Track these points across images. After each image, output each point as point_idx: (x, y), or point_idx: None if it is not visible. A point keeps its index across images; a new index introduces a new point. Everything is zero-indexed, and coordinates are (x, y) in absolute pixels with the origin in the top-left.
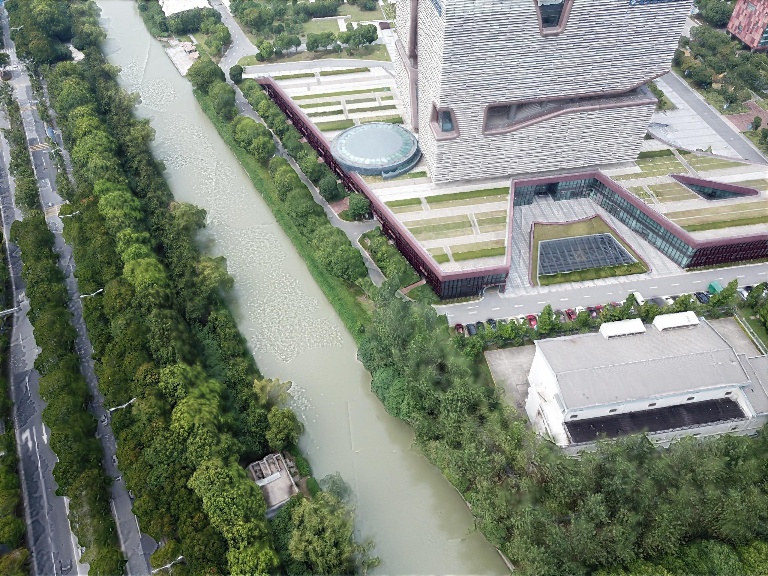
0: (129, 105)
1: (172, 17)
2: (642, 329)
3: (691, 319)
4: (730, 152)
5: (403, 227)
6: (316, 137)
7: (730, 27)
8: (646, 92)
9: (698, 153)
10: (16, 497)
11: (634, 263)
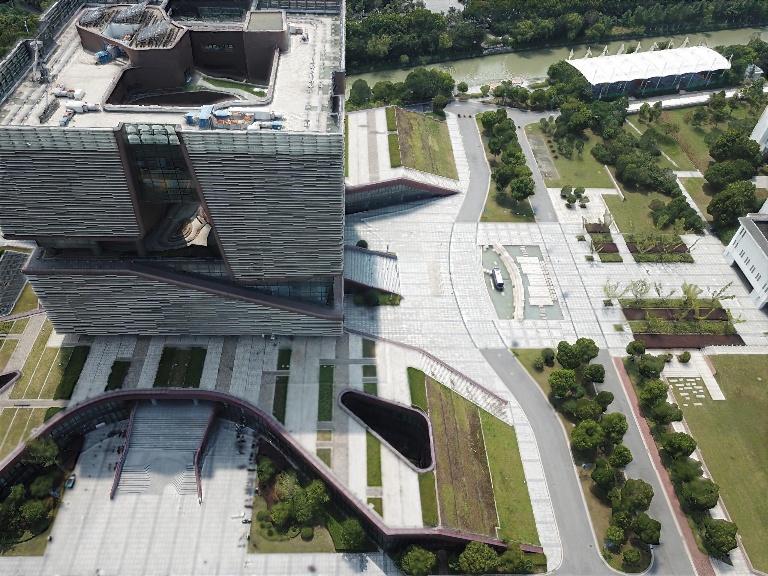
0: (369, 47)
1: (559, 62)
2: None
3: None
4: (82, 571)
5: None
6: None
7: None
8: (46, 262)
9: (38, 431)
10: (7, 38)
11: None
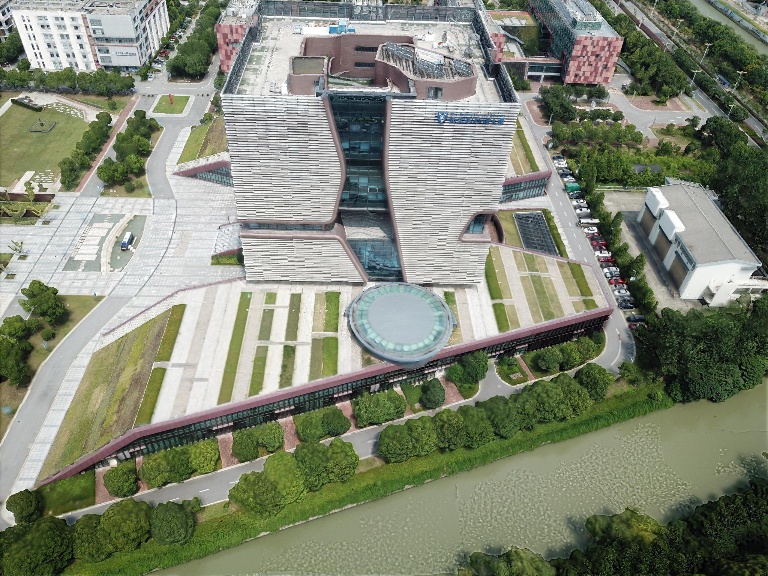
0: None
1: None
2: (674, 212)
3: (657, 191)
4: None
5: (543, 324)
6: (332, 387)
7: (226, 69)
8: None
9: None
10: None
11: (545, 213)
